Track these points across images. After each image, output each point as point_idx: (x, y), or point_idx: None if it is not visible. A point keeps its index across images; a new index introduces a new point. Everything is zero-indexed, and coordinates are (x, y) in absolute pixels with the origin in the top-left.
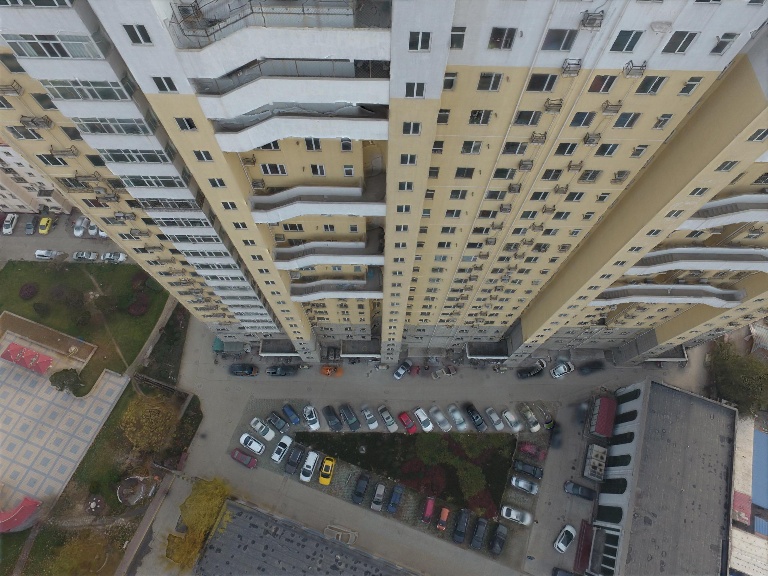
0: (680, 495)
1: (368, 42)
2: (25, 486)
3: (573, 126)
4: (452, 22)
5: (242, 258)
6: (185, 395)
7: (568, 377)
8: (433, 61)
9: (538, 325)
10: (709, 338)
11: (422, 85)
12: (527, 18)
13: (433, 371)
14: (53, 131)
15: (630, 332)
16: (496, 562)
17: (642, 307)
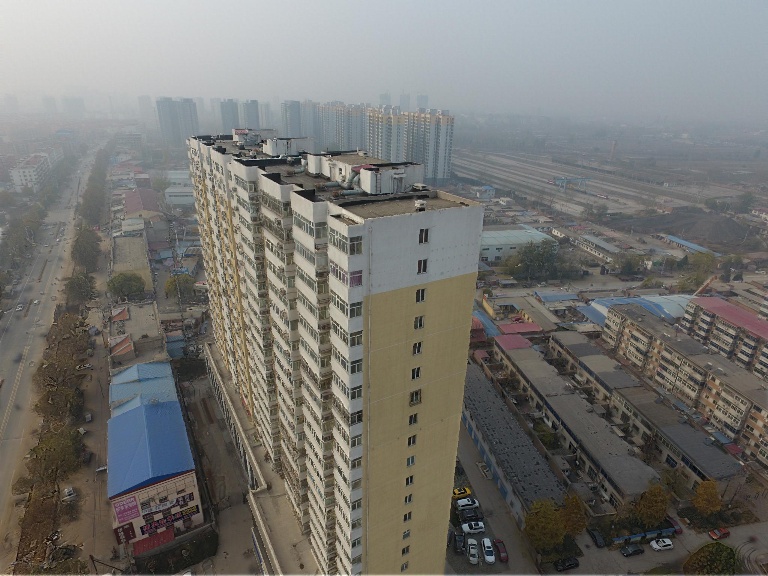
0: None
1: None
2: None
3: None
4: None
5: None
6: None
7: None
8: None
9: None
10: None
11: None
12: None
13: None
14: None
15: None
16: None
17: None
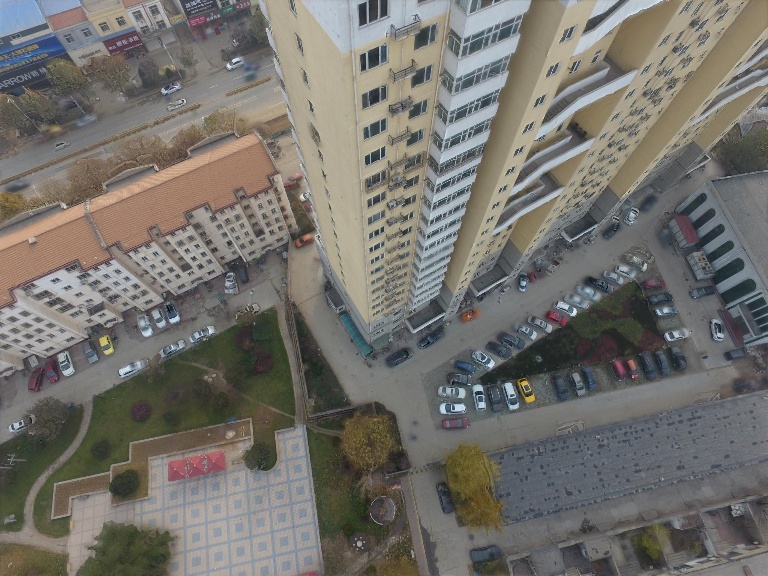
0: None
1: None
2: (282, 573)
3: None
4: None
5: (492, 196)
6: (368, 406)
7: (638, 219)
8: None
9: (640, 171)
10: None
11: None
12: None
13: (545, 269)
14: (401, 115)
15: (675, 154)
16: (686, 375)
17: None
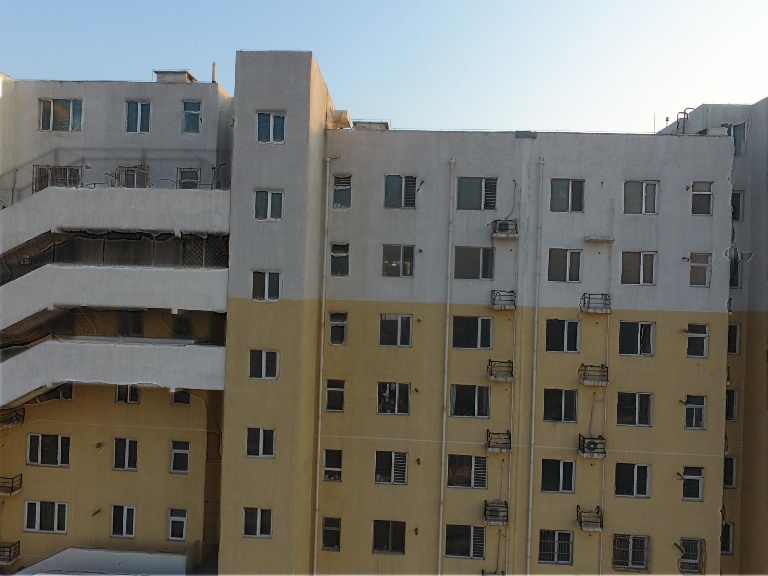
0: None
1: (201, 205)
2: None
3: (550, 421)
4: (330, 237)
5: None
6: None
7: None
8: (288, 233)
9: None
10: None
11: (276, 277)
12: (423, 232)
13: None
14: None
15: None
16: None
17: None
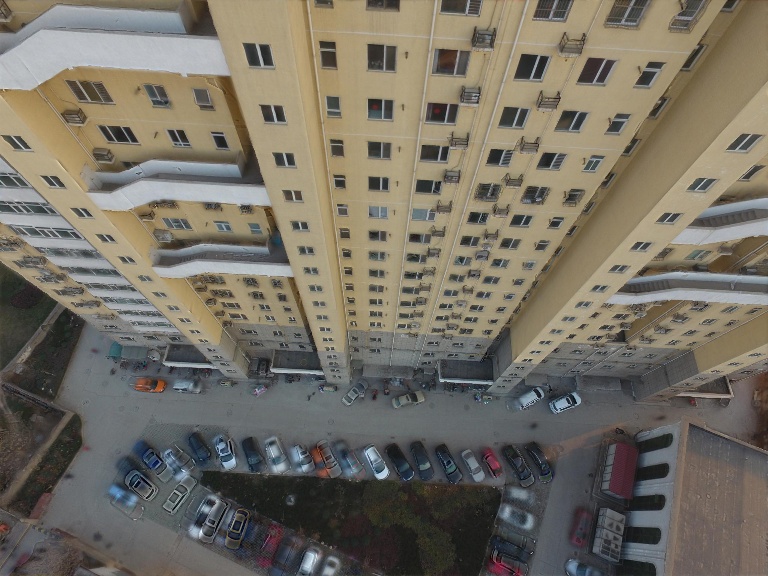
0: None
1: None
2: None
3: None
4: None
5: (28, 181)
6: (62, 414)
7: (573, 413)
8: None
9: (532, 335)
10: (764, 368)
11: None
12: None
13: (395, 397)
14: None
15: (658, 354)
16: None
17: (682, 315)
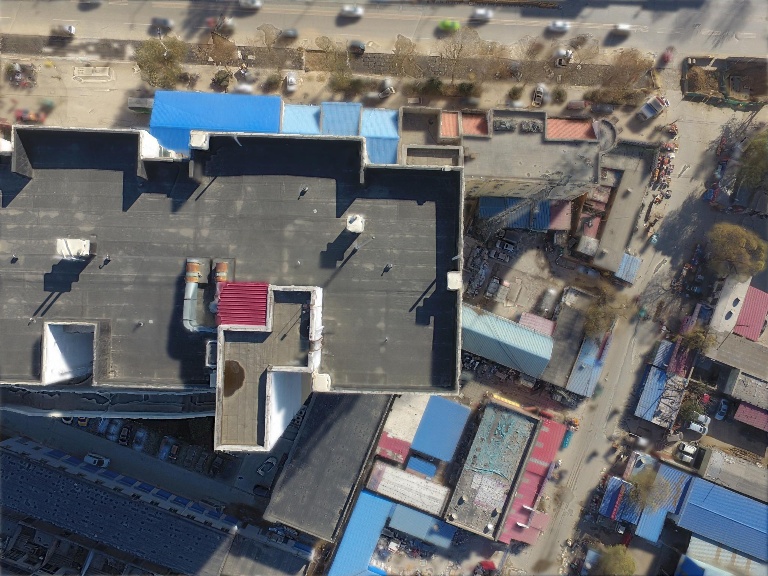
0: (330, 453)
1: None
2: None
3: None
4: None
5: None
6: None
7: None
8: None
9: None
10: None
11: None
12: None
13: None
14: None
15: None
16: (214, 480)
17: None
